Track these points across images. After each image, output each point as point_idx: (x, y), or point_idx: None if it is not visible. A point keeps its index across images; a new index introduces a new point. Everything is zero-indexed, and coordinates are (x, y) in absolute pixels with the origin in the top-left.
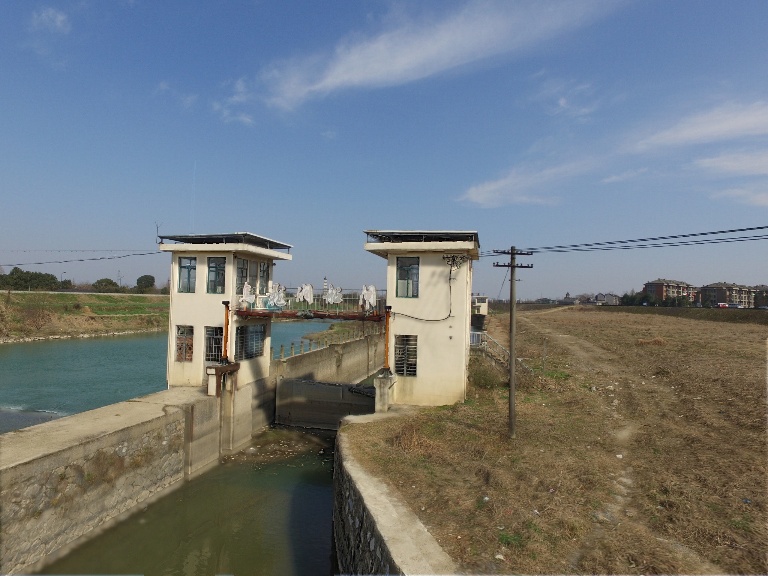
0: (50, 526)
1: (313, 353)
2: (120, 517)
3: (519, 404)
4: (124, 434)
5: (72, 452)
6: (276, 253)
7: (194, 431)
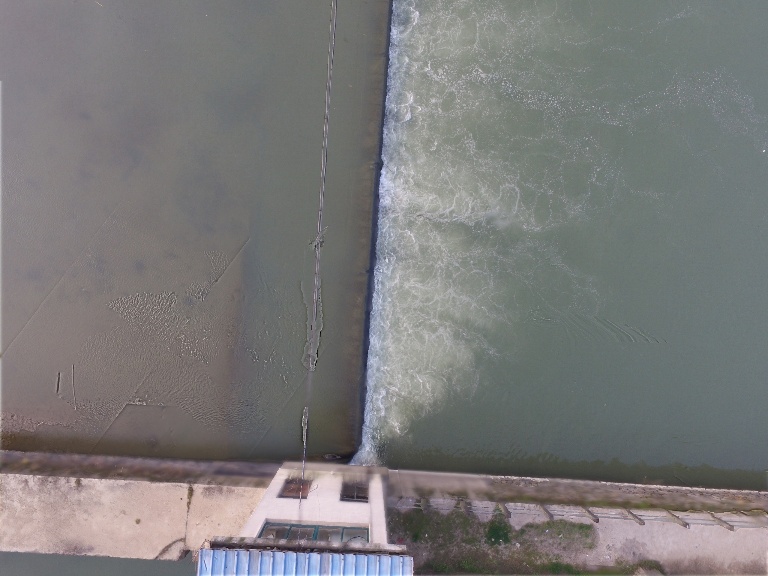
0: None
1: None
2: None
3: None
4: None
5: None
6: None
7: None
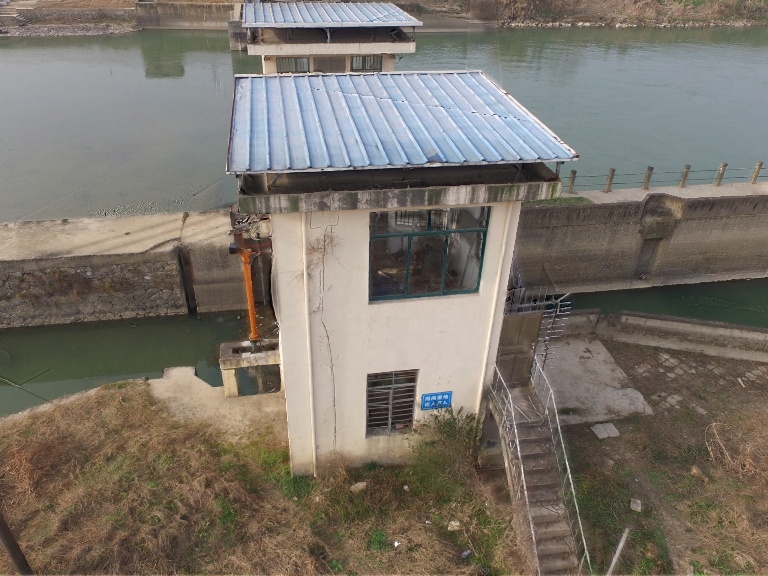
0: (24, 309)
1: (536, 210)
2: (101, 323)
3: (299, 572)
4: (84, 261)
5: (25, 264)
6: (352, 47)
7: (197, 275)
